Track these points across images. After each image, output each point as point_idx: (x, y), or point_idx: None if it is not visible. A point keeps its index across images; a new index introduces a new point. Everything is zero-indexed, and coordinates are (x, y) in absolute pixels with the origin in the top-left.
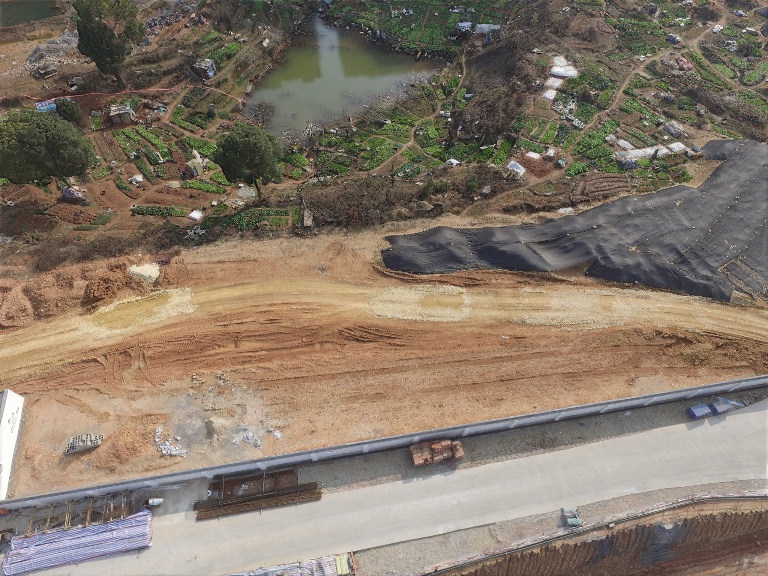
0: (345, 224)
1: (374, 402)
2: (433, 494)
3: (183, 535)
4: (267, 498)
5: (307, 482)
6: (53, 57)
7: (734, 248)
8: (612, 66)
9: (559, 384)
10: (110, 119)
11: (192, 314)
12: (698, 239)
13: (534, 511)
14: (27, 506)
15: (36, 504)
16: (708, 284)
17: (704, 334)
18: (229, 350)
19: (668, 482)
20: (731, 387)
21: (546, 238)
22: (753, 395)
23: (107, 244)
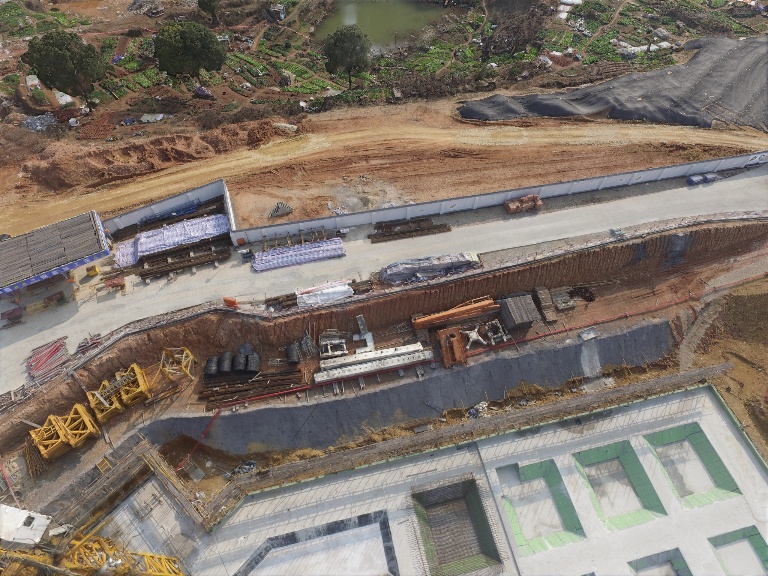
0: (425, 95)
1: (473, 185)
2: (525, 226)
3: (365, 250)
4: (415, 232)
5: (439, 224)
6: (152, 5)
7: (712, 97)
8: None
9: (598, 172)
10: None
11: (330, 147)
12: (686, 93)
13: (593, 231)
14: (256, 241)
15: (265, 235)
16: (695, 116)
17: (695, 145)
18: (363, 165)
19: (678, 215)
20: (715, 167)
21: (576, 97)
22: (731, 173)
23: (251, 112)
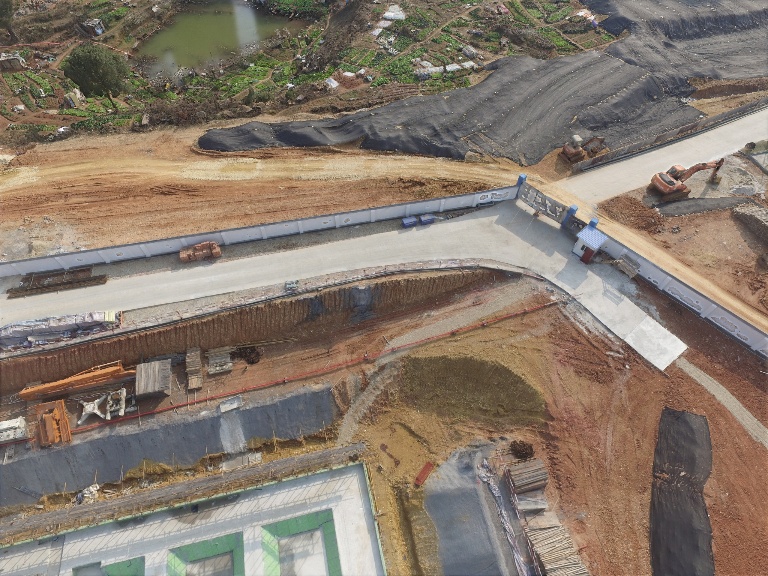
0: (176, 122)
1: (164, 228)
2: (192, 277)
3: None
4: (65, 284)
5: (98, 275)
6: None
7: (480, 125)
8: (440, 12)
9: (312, 213)
10: (2, 65)
11: (35, 183)
12: (453, 120)
13: (265, 284)
14: None
15: None
16: (449, 147)
17: (437, 180)
18: (59, 203)
19: (371, 264)
20: (439, 207)
21: (335, 125)
22: (457, 213)
23: None
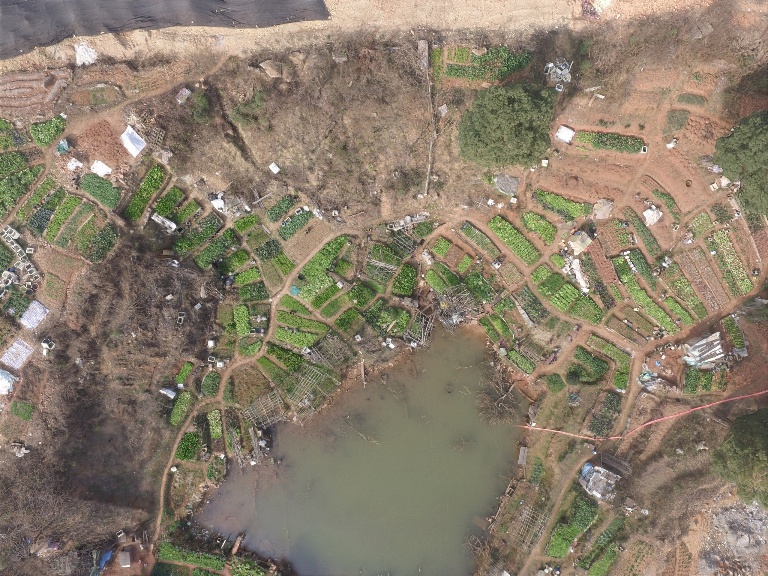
0: None
1: None
2: None
3: None
4: None
5: None
6: None
7: None
8: None
9: None
10: None
11: None
12: None
13: None
14: None
15: None
16: None
17: None
18: None
19: None
20: None
21: None
22: None
23: (660, 34)
